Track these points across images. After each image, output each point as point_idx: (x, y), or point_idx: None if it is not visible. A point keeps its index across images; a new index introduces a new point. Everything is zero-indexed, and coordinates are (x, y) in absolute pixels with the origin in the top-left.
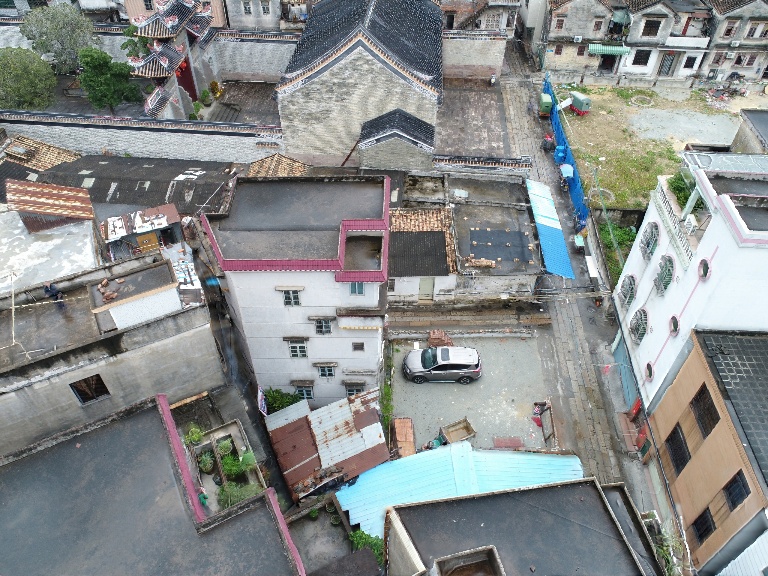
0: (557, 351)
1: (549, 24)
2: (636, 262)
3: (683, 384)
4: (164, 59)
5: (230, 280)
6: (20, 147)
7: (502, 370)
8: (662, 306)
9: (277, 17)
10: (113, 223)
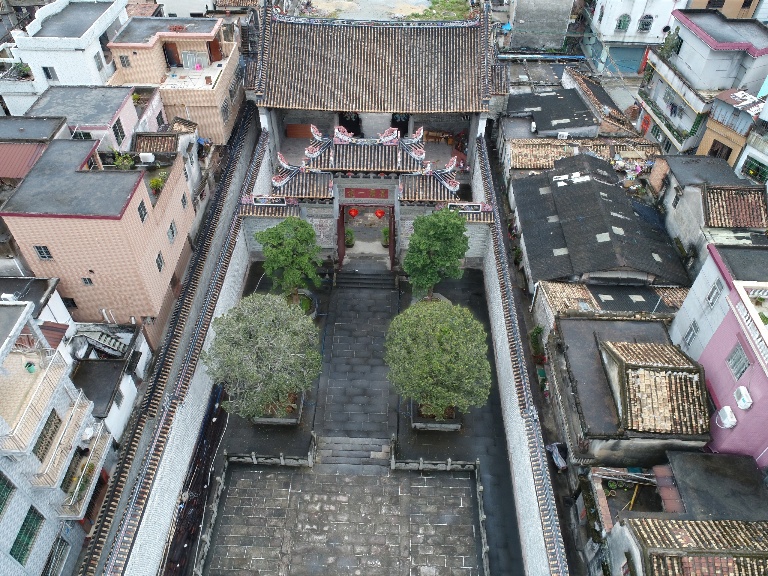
0: (608, 86)
1: (254, 20)
2: (622, 8)
3: (698, 7)
4: (452, 161)
5: (765, 68)
6: (580, 306)
7: (633, 100)
8: (662, 0)
9: (196, 160)
10: (755, 111)
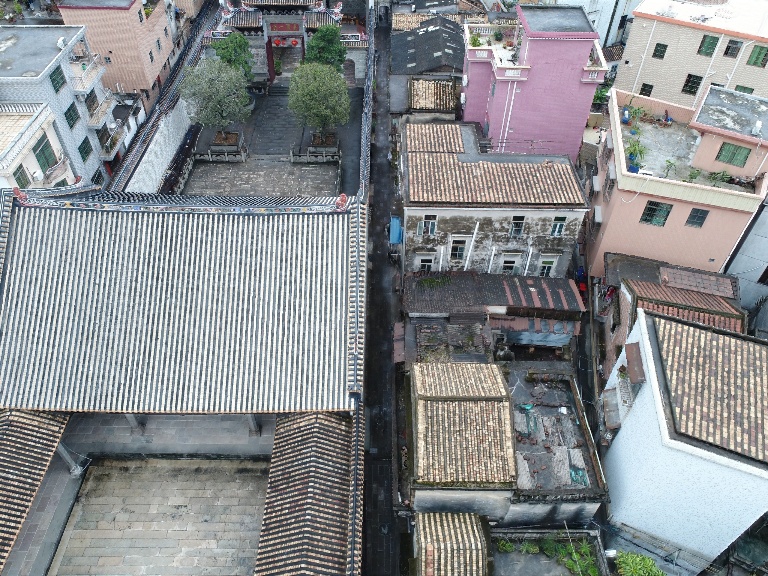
0: None
1: None
2: None
3: None
4: (339, 5)
5: None
6: None
7: None
8: None
9: (174, 20)
10: None
